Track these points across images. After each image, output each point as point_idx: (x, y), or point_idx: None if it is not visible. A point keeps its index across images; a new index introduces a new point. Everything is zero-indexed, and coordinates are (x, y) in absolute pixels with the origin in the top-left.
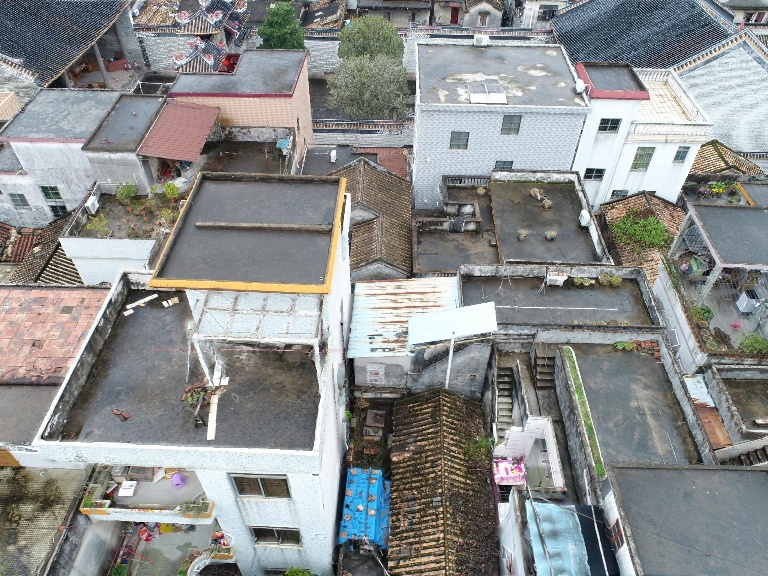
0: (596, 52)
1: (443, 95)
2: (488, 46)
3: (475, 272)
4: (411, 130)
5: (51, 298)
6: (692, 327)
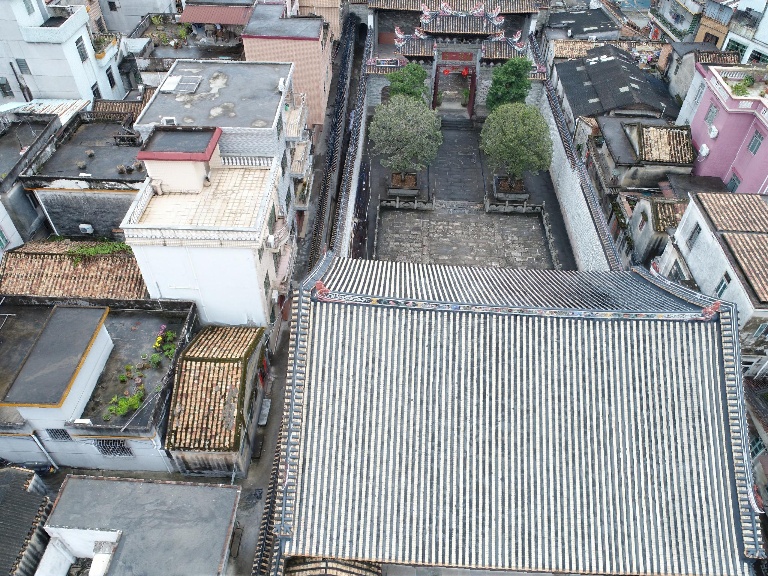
0: None
1: (191, 70)
2: None
3: (55, 125)
4: None
5: None
6: None
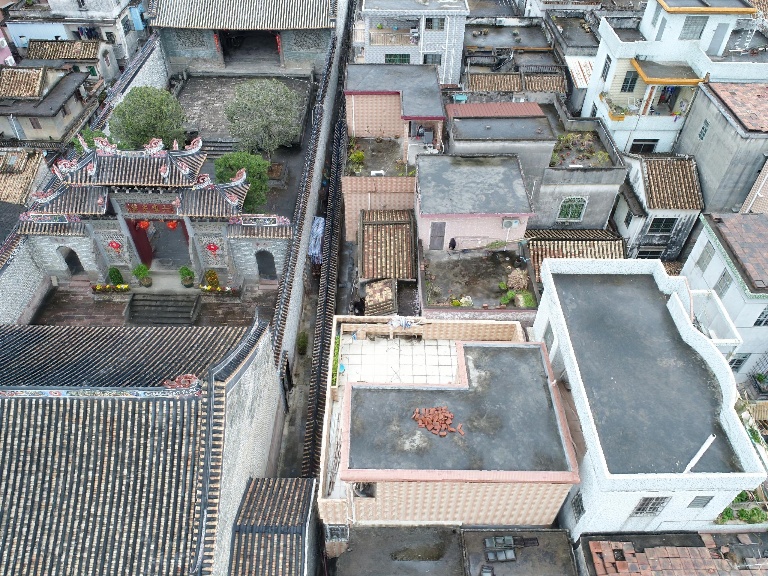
0: (250, 7)
1: (451, 6)
2: None
3: None
4: (323, 108)
5: (730, 99)
6: (586, 3)
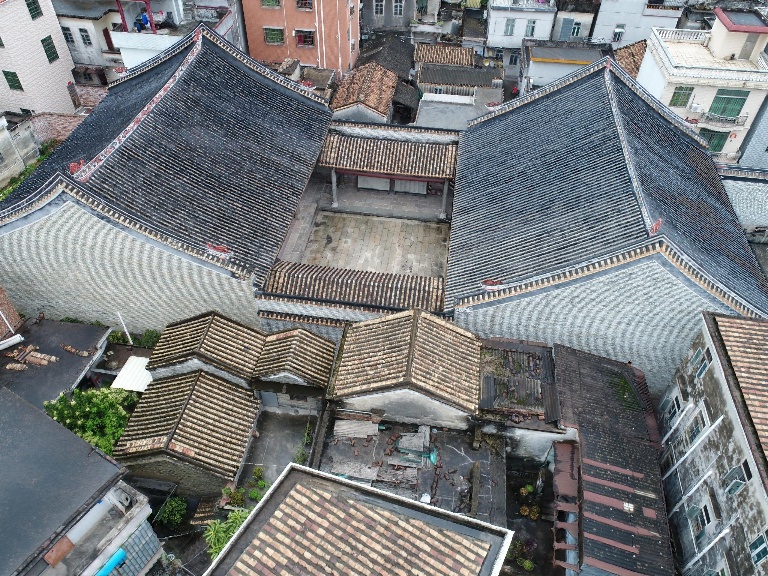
0: None
1: None
2: None
3: None
4: None
5: None
6: None
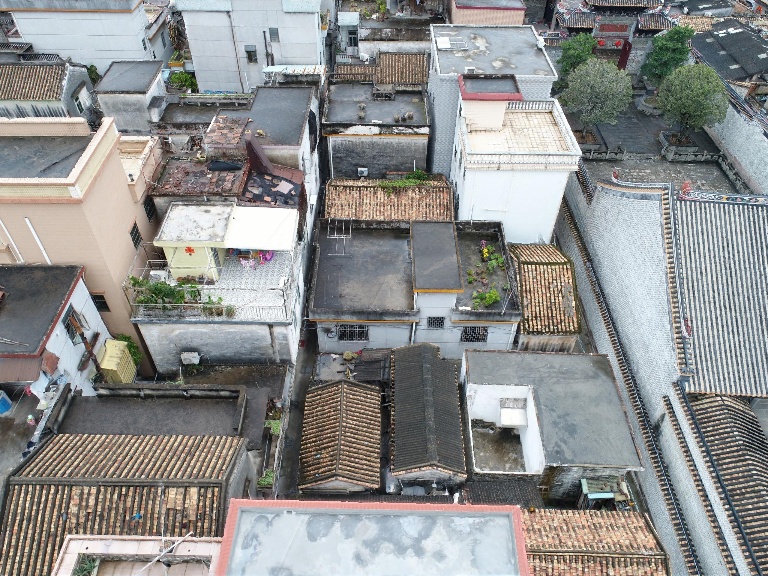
0: None
1: (449, 33)
2: (541, 50)
3: None
4: None
5: None
6: None
